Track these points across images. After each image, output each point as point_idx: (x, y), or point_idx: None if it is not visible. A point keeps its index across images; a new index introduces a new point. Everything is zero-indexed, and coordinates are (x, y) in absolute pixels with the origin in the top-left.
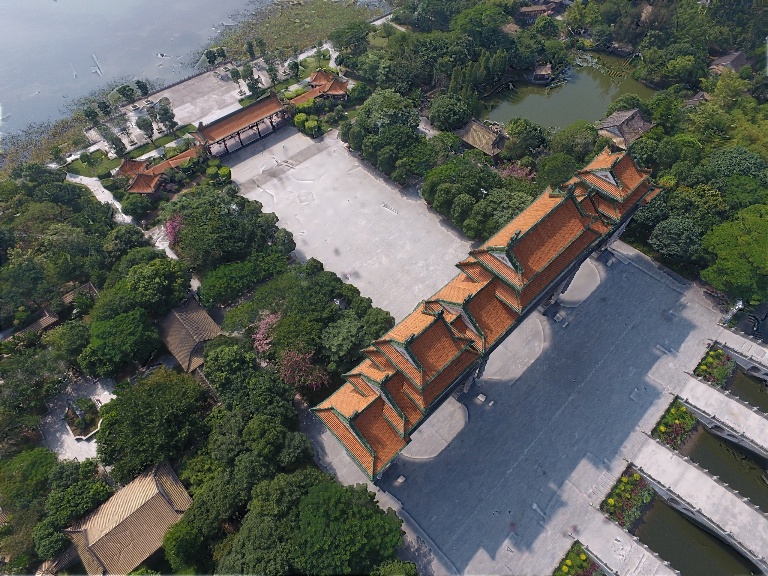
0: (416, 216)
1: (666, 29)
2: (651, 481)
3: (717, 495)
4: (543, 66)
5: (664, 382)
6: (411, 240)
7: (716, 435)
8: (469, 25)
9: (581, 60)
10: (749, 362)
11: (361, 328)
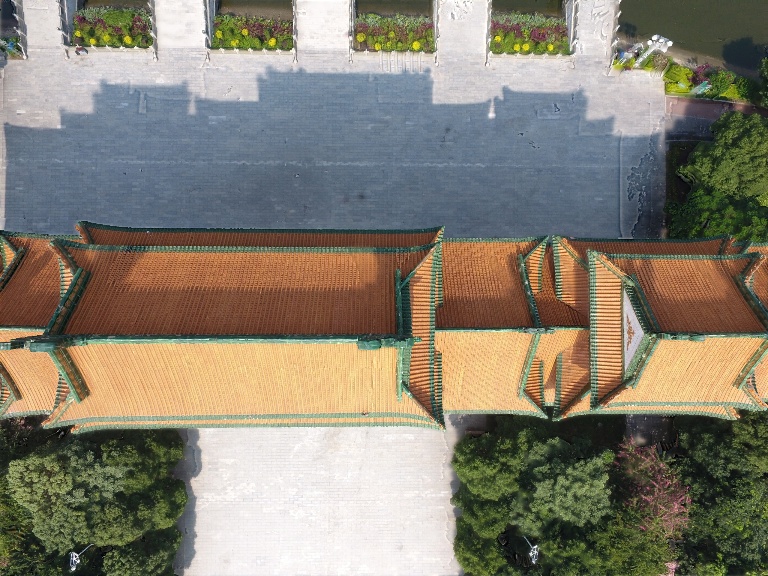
0: None
1: None
2: None
3: None
4: None
5: (197, 75)
6: (268, 570)
7: None
8: None
9: None
10: None
11: (520, 480)
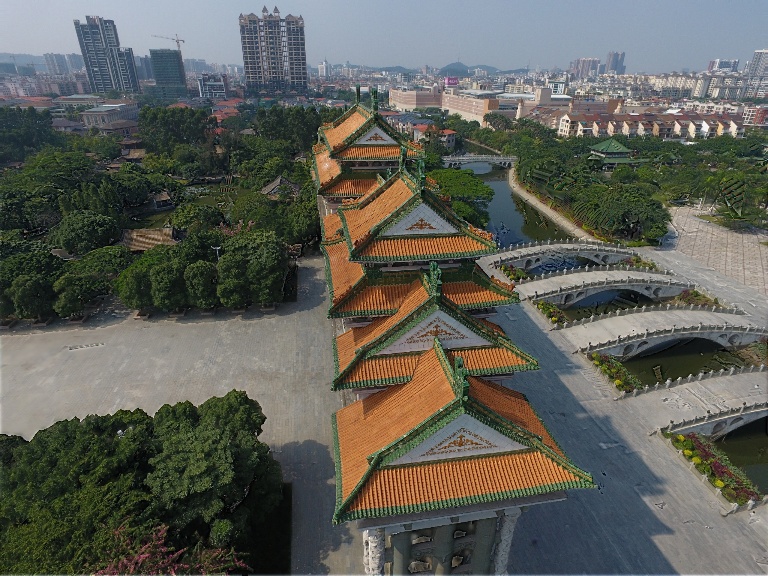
0: (136, 333)
1: (243, 148)
2: (604, 349)
3: (633, 321)
4: (159, 193)
5: None
6: (156, 354)
7: (571, 306)
8: (44, 172)
9: (188, 191)
10: (522, 260)
11: None
